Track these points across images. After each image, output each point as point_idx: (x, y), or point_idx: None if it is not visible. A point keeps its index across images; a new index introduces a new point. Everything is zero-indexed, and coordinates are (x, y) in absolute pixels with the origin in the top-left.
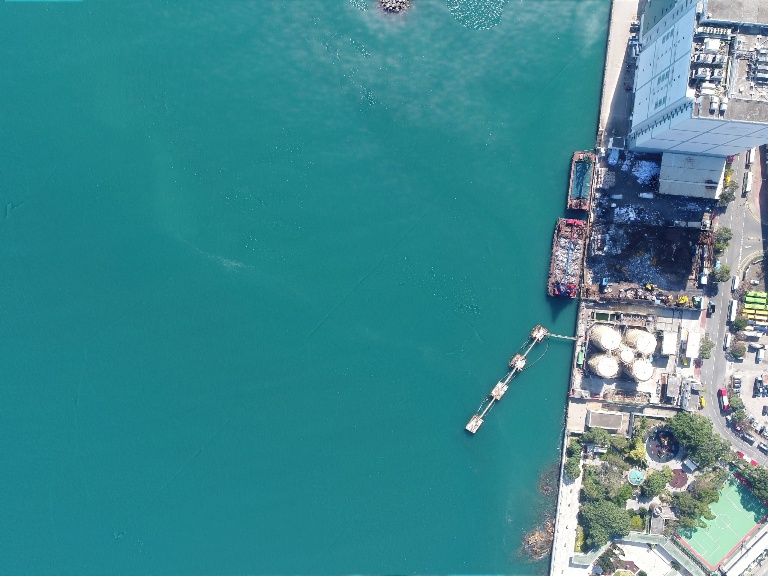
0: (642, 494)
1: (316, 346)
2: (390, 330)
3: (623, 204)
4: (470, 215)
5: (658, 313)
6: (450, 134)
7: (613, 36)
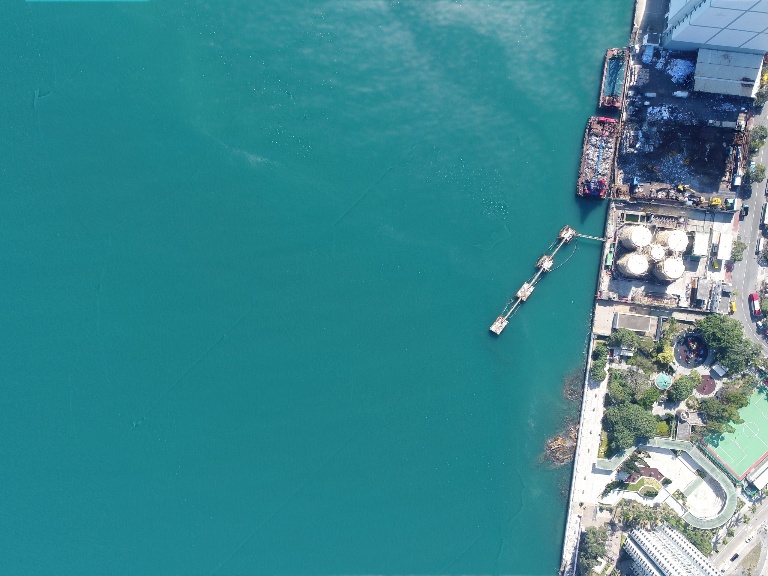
0: (669, 399)
1: (342, 234)
2: (416, 228)
3: (656, 103)
4: (501, 105)
5: (689, 215)
6: (482, 30)
7: None
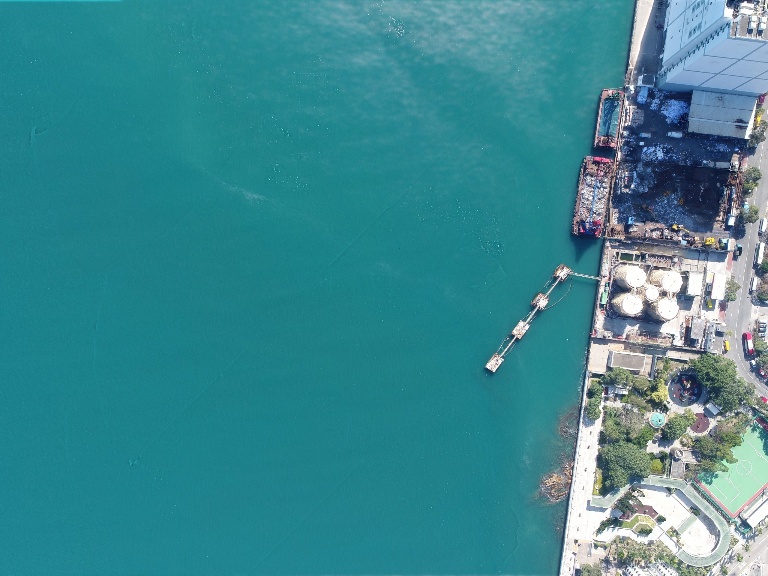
0: (663, 437)
1: (338, 275)
2: (412, 266)
3: (651, 143)
4: (497, 147)
5: (684, 255)
6: (478, 69)
7: None
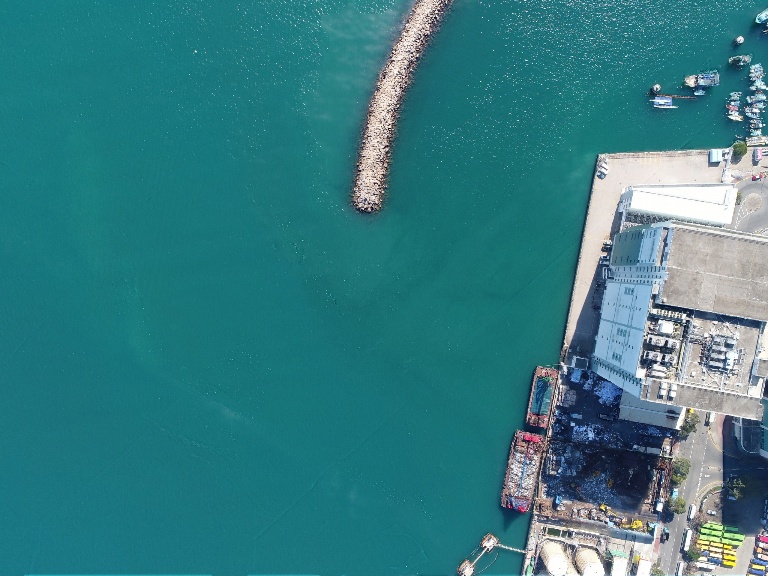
0: None
1: (262, 550)
2: (341, 524)
3: (583, 422)
4: (424, 433)
5: (611, 534)
6: (414, 337)
7: (584, 253)
